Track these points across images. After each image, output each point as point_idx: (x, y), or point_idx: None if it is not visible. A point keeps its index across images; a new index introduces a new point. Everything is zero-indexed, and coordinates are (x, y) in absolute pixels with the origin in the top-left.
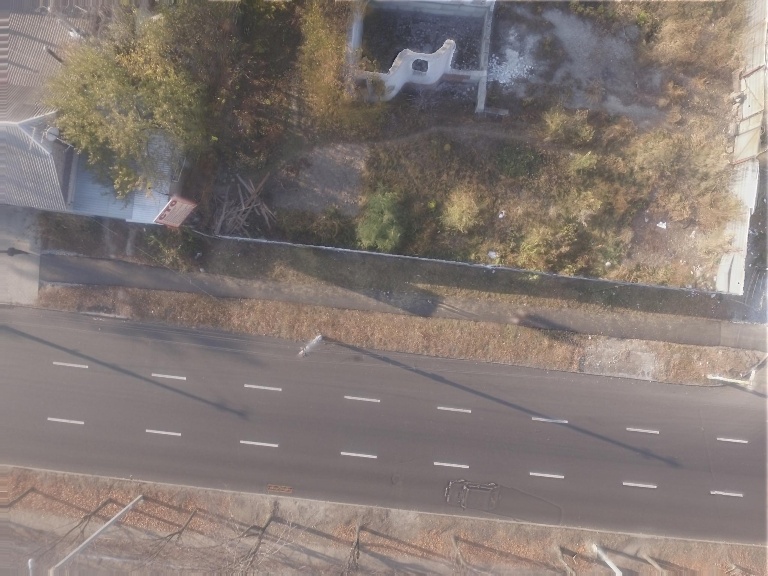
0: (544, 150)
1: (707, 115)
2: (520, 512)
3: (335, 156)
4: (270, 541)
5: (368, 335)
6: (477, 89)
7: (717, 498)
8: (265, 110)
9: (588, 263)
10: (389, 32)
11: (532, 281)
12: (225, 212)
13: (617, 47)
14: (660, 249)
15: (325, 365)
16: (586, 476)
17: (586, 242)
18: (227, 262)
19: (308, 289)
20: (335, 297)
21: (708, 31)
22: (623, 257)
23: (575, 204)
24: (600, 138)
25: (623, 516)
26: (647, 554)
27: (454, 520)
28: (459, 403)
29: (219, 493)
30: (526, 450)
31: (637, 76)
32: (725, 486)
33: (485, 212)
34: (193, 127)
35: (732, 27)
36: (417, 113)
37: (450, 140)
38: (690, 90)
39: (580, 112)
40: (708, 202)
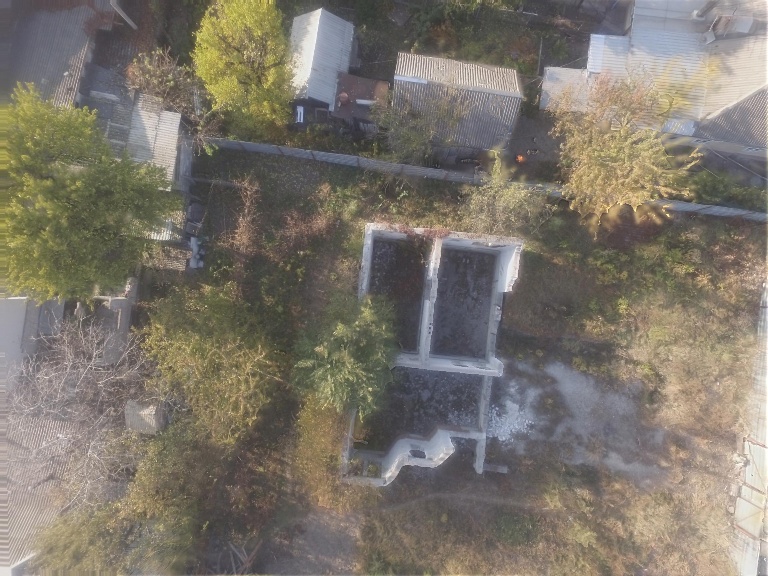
0: (543, 518)
1: (709, 474)
2: None
3: (330, 523)
4: None
5: None
6: (476, 442)
7: None
8: (258, 477)
9: None
10: None
11: None
12: None
13: (620, 403)
14: None
15: None
16: None
17: None
18: None
19: None
20: None
21: (713, 390)
22: None
23: (573, 573)
24: (600, 502)
25: None
26: None
27: None
28: None
29: None
30: None
31: (639, 433)
32: None
33: None
34: (183, 536)
35: None
36: (414, 482)
37: (447, 509)
38: (693, 449)
39: (580, 491)
40: None
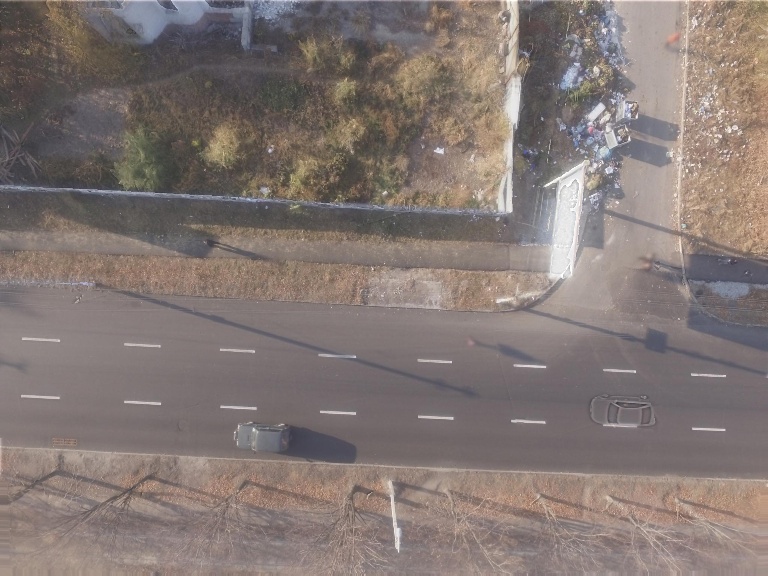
0: (308, 81)
1: (477, 37)
2: (313, 452)
3: (99, 102)
4: (57, 496)
5: (143, 280)
6: None
7: (518, 426)
8: (26, 60)
9: (361, 192)
10: None
11: (307, 215)
12: None
13: None
14: (439, 175)
15: (102, 313)
16: (379, 411)
17: (361, 172)
18: None
19: (81, 237)
20: (108, 244)
21: None
22: (401, 185)
23: (343, 133)
24: (366, 66)
25: (421, 450)
26: (447, 488)
27: (244, 464)
28: (242, 344)
29: (2, 450)
30: (314, 388)
31: (404, 3)
32: (526, 414)
33: (249, 147)
34: None
35: None
36: (177, 53)
37: (212, 78)
38: (458, 13)
39: (336, 39)
40: (483, 124)
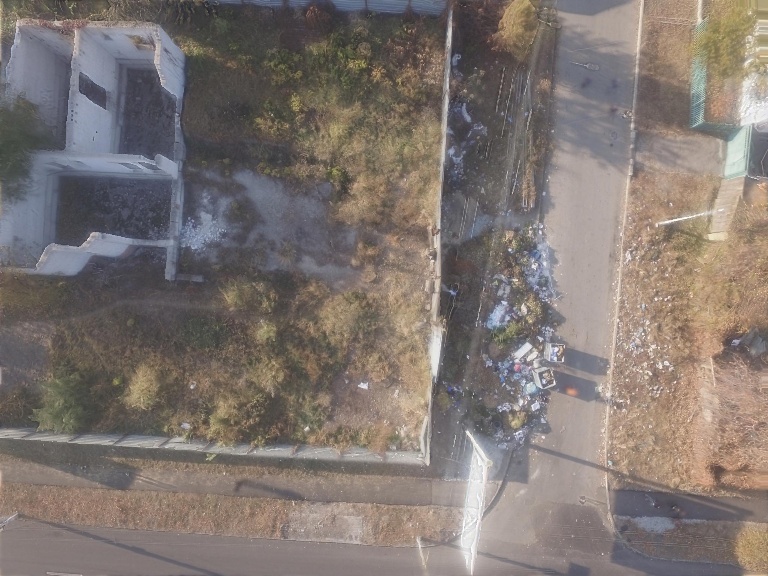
0: (231, 320)
1: (403, 272)
2: None
3: (23, 334)
4: None
5: (66, 511)
6: None
7: None
8: None
9: (281, 432)
10: (87, 198)
11: (228, 451)
12: None
13: (310, 206)
14: (363, 410)
15: (25, 542)
16: None
17: (283, 408)
18: None
19: (5, 466)
20: (32, 474)
21: (400, 187)
22: (324, 420)
23: (264, 373)
24: (290, 303)
25: None
26: None
27: None
28: (163, 575)
29: None
30: None
31: (331, 235)
32: None
33: (170, 387)
34: None
35: (424, 182)
36: (100, 289)
37: (135, 314)
38: (385, 247)
39: (256, 284)
40: (407, 362)
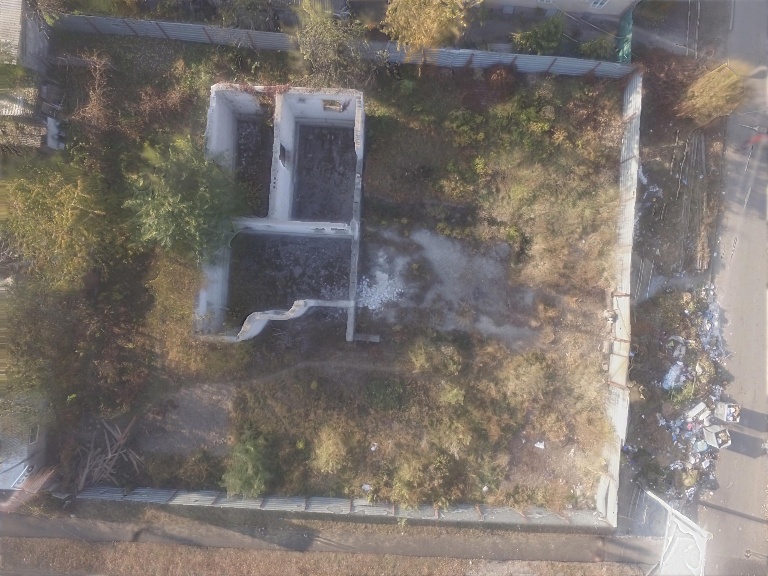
0: (413, 382)
1: (581, 333)
2: None
3: (202, 396)
4: None
5: (244, 573)
6: None
7: None
8: (128, 353)
9: (463, 493)
10: (258, 256)
11: None
12: (89, 464)
13: (487, 267)
14: (539, 469)
15: None
16: None
17: (462, 468)
18: (97, 507)
19: (181, 529)
20: (209, 536)
21: (579, 248)
22: (501, 480)
23: (447, 435)
24: (471, 364)
25: None
26: None
27: None
28: None
29: None
30: None
31: (509, 295)
32: None
33: (354, 450)
34: (41, 401)
35: (603, 244)
36: (282, 351)
37: (317, 376)
38: (563, 308)
39: (445, 348)
40: (585, 422)
